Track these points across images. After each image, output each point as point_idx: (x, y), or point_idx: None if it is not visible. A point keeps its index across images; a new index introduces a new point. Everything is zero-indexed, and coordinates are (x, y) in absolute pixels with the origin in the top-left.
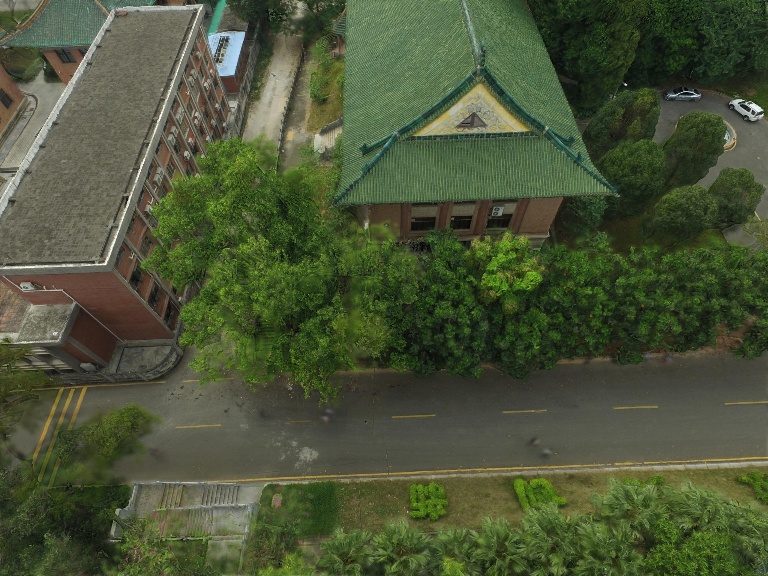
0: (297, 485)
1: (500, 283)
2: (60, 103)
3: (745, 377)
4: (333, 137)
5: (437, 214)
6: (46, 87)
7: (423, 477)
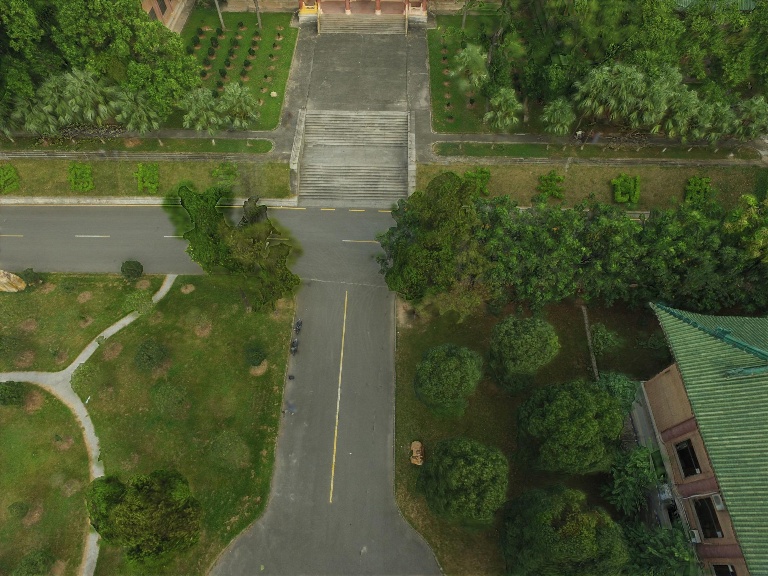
0: None
1: None
2: None
3: None
4: None
5: None
6: None
7: None
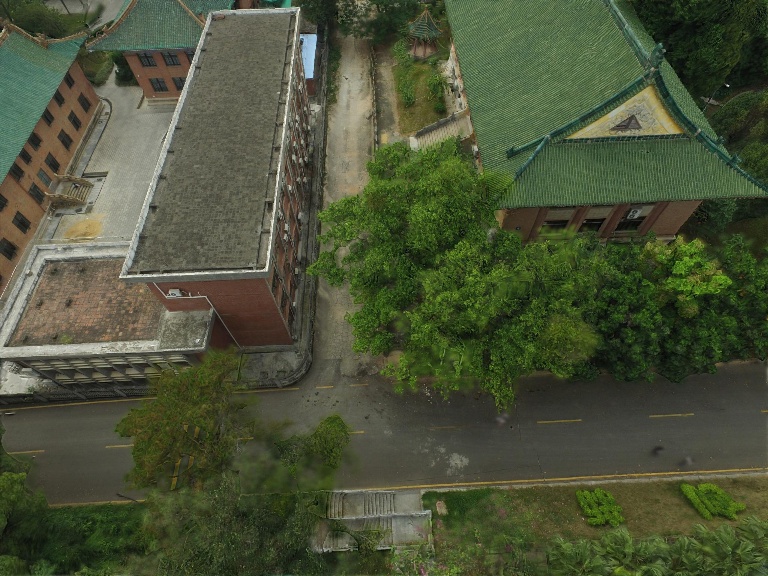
0: (456, 492)
1: (692, 287)
2: (179, 107)
3: None
4: (431, 140)
5: (571, 217)
6: (118, 91)
7: (583, 483)
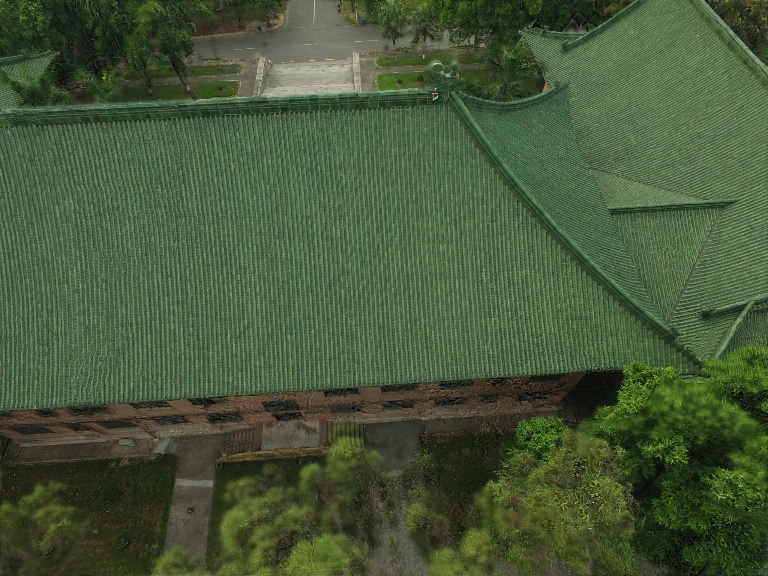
0: None
1: None
2: None
3: (252, 41)
4: None
5: None
6: None
7: None
